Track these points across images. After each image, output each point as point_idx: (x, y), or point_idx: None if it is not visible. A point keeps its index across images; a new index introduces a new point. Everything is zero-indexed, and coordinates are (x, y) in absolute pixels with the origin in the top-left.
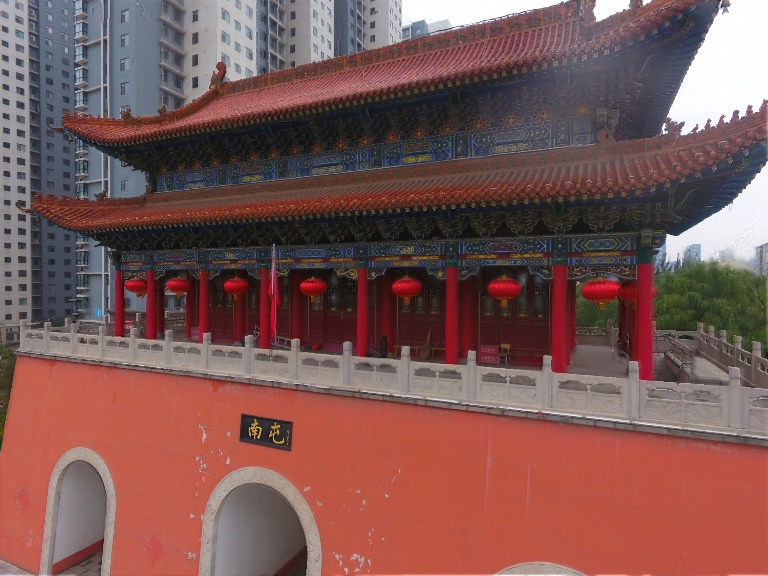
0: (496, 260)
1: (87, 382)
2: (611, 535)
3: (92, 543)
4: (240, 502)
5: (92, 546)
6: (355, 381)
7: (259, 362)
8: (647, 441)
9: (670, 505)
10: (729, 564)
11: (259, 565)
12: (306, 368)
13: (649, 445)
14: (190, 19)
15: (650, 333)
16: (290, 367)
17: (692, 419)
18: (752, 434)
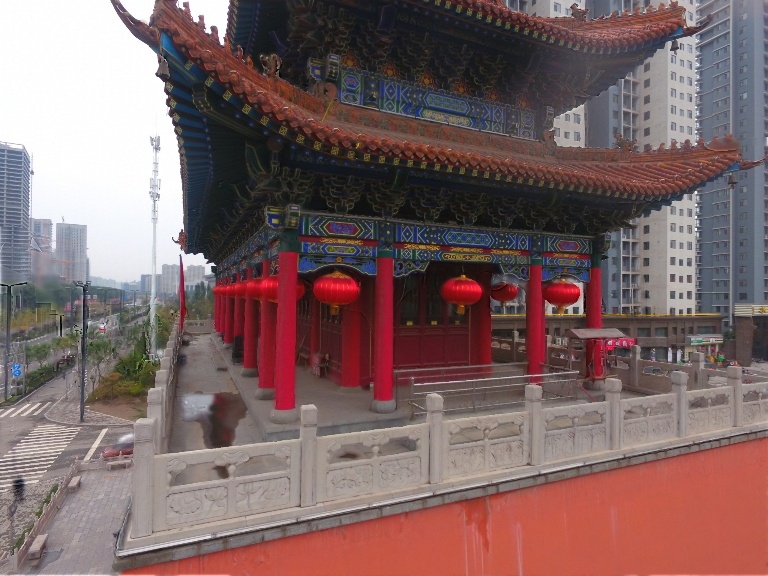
0: (256, 258)
1: None
2: None
3: None
4: None
5: None
6: None
7: None
8: None
9: None
10: None
11: None
12: None
13: None
14: None
15: (281, 345)
16: None
17: None
18: None
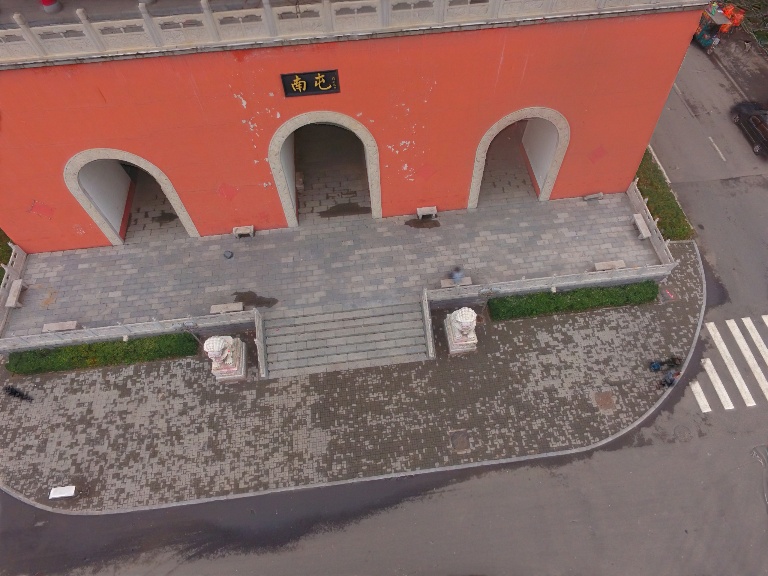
0: None
1: (45, 88)
2: (566, 83)
3: (124, 208)
4: None
5: (125, 210)
6: (393, 21)
7: (285, 21)
8: (604, 23)
9: (602, 58)
10: (618, 80)
11: (291, 167)
12: (342, 18)
13: (604, 26)
14: None
15: None
16: (324, 20)
17: (632, 2)
18: (661, 6)
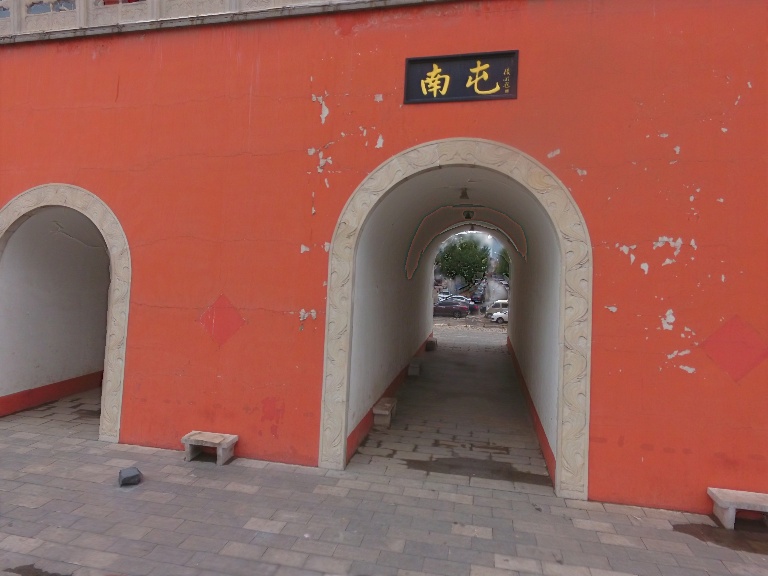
0: None
1: (54, 72)
2: None
3: (52, 382)
4: (370, 244)
5: (52, 386)
6: None
7: None
8: None
9: None
10: None
11: (376, 367)
12: None
13: None
14: None
15: None
16: None
17: None
18: None
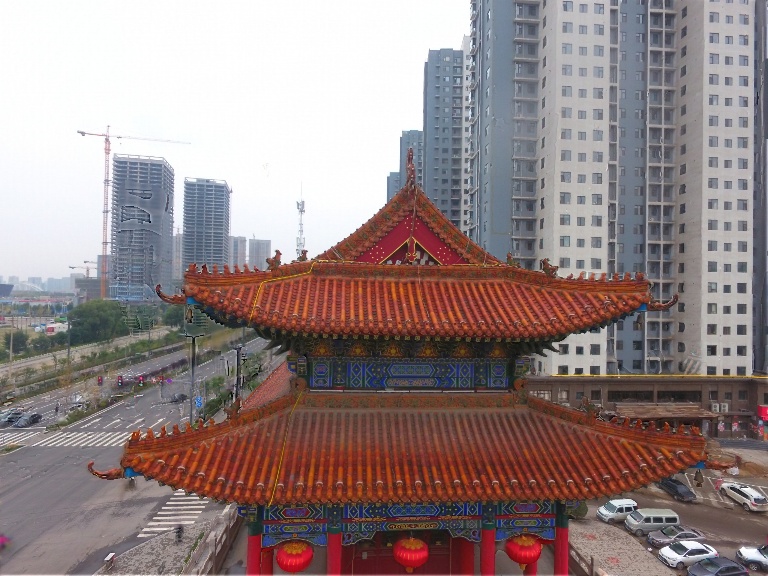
0: None
1: None
2: None
3: None
4: None
5: None
6: None
7: None
8: None
9: None
10: None
11: None
12: None
13: None
14: (541, 107)
15: None
16: None
17: None
18: None
